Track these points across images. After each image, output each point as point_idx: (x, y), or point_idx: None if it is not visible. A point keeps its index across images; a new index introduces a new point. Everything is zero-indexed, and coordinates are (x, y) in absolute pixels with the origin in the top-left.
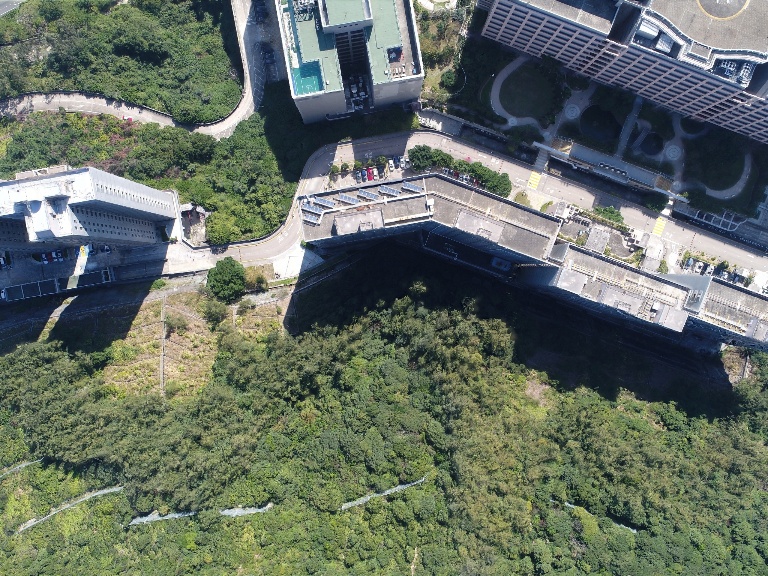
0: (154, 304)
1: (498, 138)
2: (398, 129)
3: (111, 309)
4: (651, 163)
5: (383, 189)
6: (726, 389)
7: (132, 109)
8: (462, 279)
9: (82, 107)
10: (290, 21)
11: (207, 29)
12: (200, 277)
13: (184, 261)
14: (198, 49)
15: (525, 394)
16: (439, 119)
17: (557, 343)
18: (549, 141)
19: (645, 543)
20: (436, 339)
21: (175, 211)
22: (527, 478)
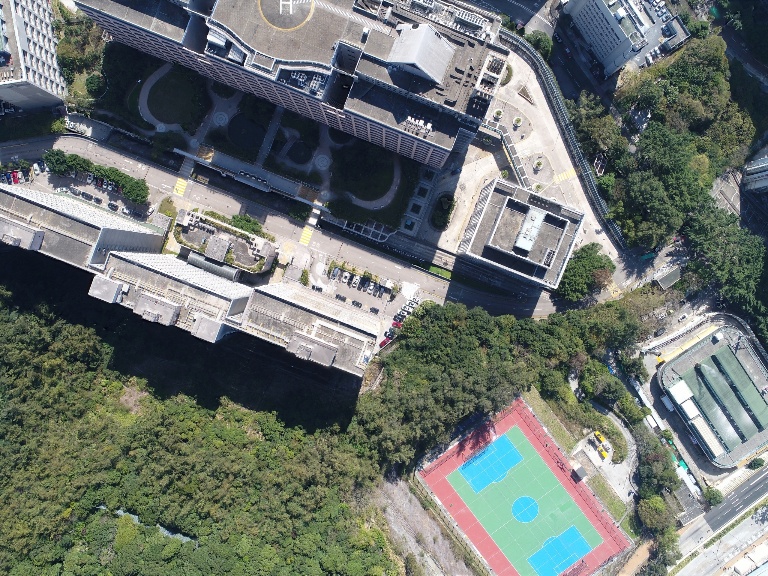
0: None
1: (150, 144)
2: (40, 133)
3: None
4: (291, 172)
5: None
6: (350, 400)
7: None
8: (75, 284)
9: None
10: None
11: None
12: None
13: None
14: None
15: (118, 401)
16: (89, 124)
17: (167, 350)
18: (196, 148)
19: (183, 553)
20: (12, 344)
21: None
22: (73, 485)
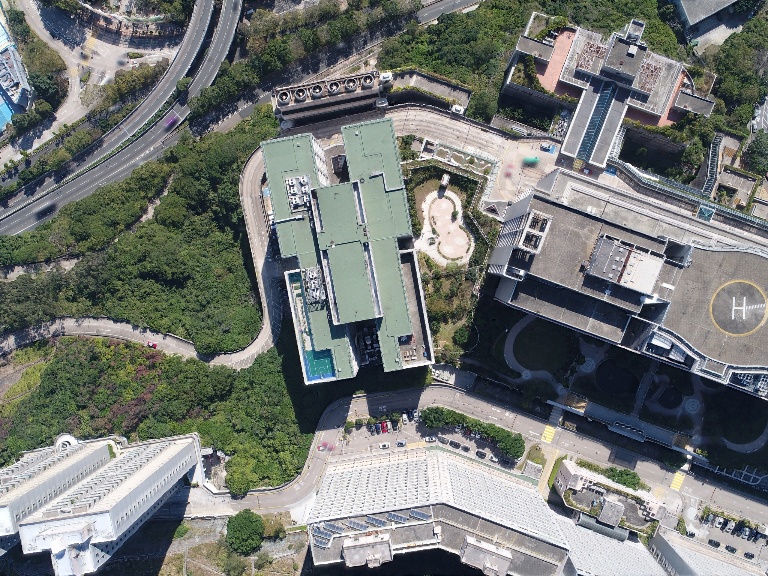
0: (176, 558)
1: None
2: (411, 386)
3: (136, 560)
4: (669, 423)
5: (391, 516)
6: None
7: (156, 335)
8: None
9: (110, 331)
10: (303, 306)
11: (228, 245)
12: (220, 522)
13: (205, 504)
14: (219, 271)
15: None
16: (453, 370)
17: None
18: (564, 395)
19: None
20: None
21: (196, 456)
22: None
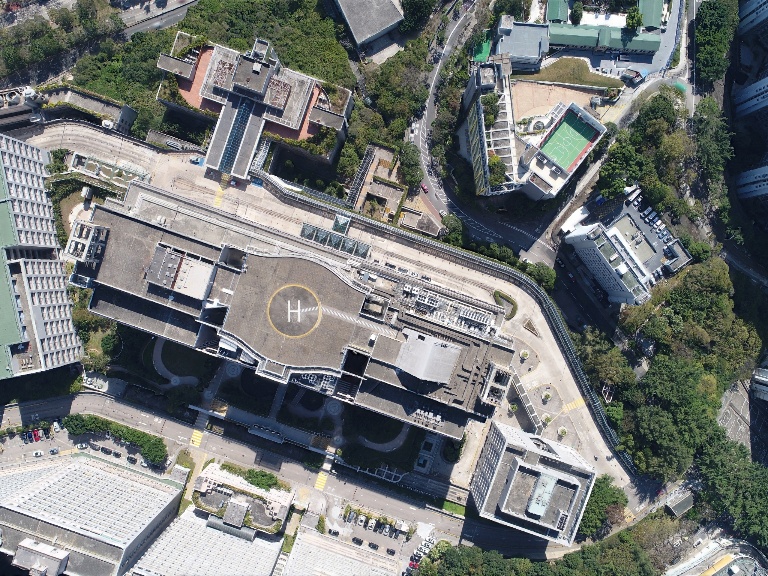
0: None
1: None
2: (59, 394)
3: None
4: (304, 424)
5: None
6: None
7: None
8: None
9: None
10: None
11: None
12: None
13: None
14: None
15: None
16: (106, 378)
17: None
18: (210, 399)
19: None
20: None
21: None
22: None
